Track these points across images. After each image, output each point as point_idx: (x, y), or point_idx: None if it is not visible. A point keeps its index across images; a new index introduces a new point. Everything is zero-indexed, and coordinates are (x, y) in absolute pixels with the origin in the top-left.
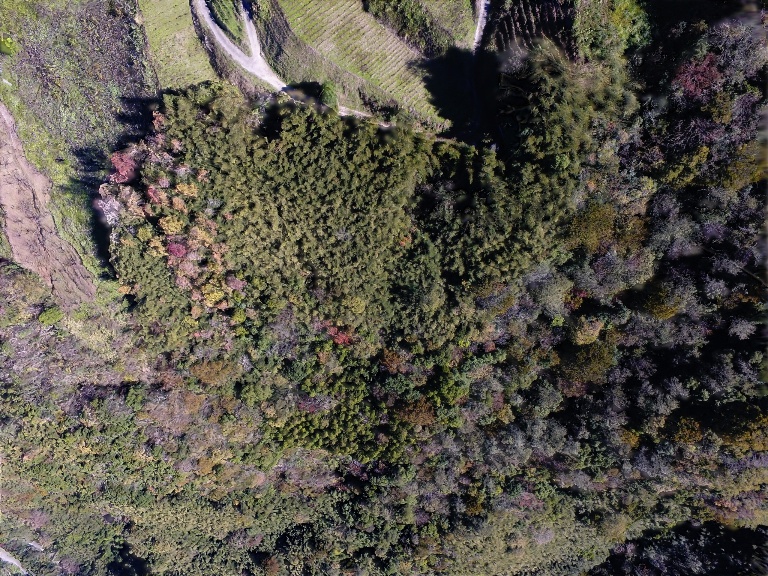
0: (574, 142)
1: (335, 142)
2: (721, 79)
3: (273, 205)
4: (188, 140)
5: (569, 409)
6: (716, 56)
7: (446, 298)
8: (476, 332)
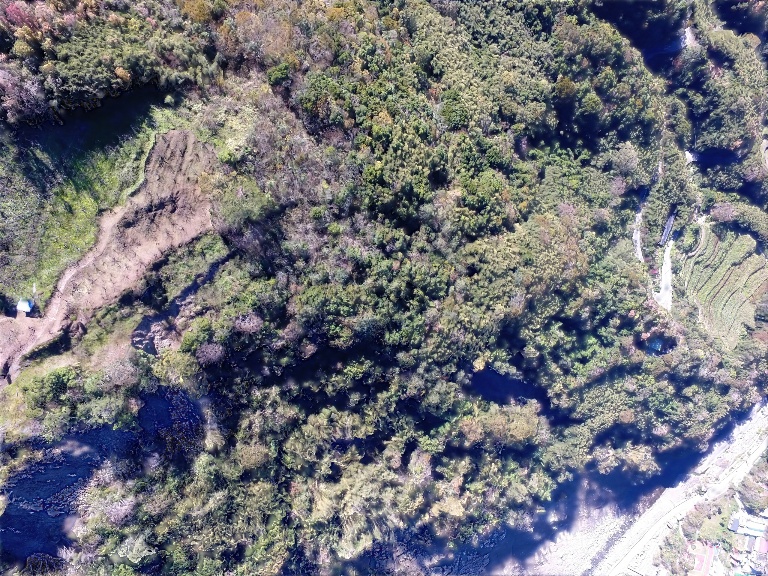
0: None
1: None
2: None
3: None
4: None
5: None
6: None
7: None
8: None
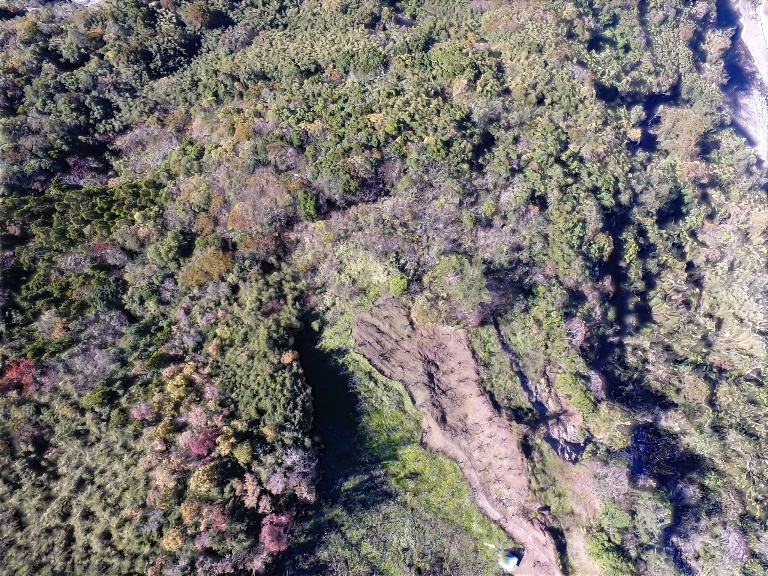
0: None
1: None
2: None
3: (79, 544)
4: None
5: None
6: None
7: None
8: None
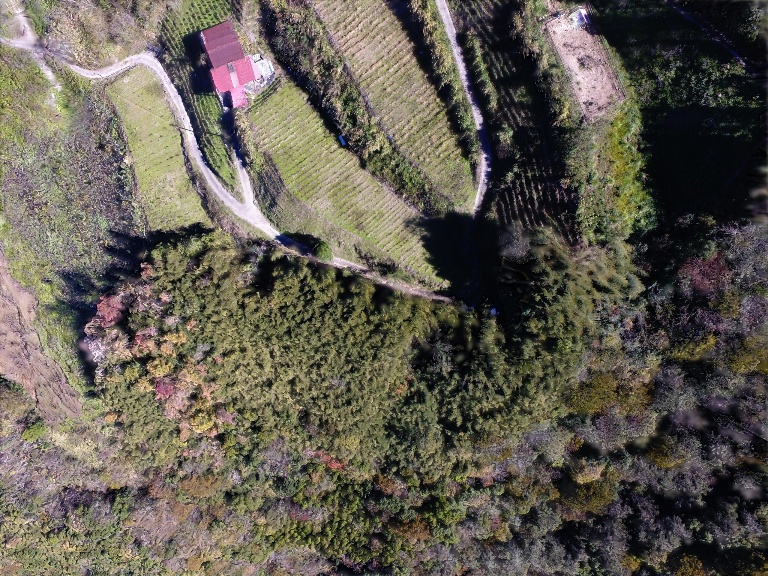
0: (577, 329)
1: (329, 304)
2: (729, 271)
3: (265, 349)
4: (177, 292)
5: (568, 528)
6: (724, 251)
7: (443, 441)
8: (474, 471)
